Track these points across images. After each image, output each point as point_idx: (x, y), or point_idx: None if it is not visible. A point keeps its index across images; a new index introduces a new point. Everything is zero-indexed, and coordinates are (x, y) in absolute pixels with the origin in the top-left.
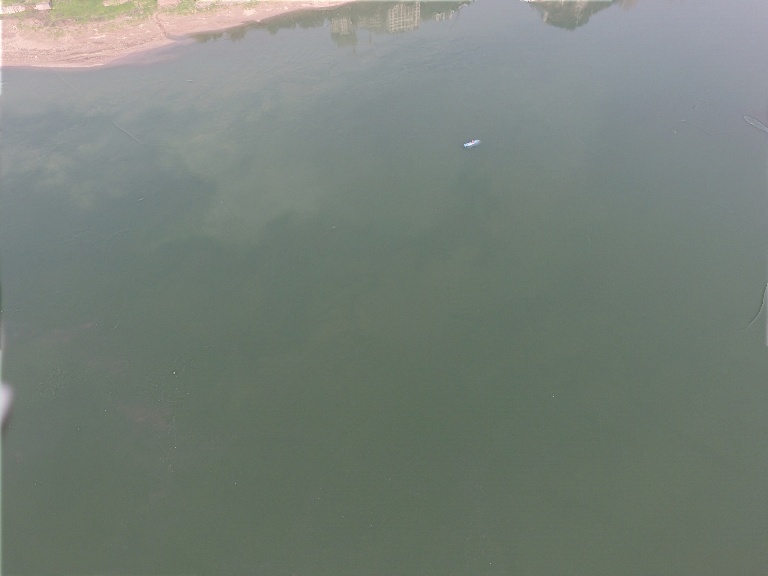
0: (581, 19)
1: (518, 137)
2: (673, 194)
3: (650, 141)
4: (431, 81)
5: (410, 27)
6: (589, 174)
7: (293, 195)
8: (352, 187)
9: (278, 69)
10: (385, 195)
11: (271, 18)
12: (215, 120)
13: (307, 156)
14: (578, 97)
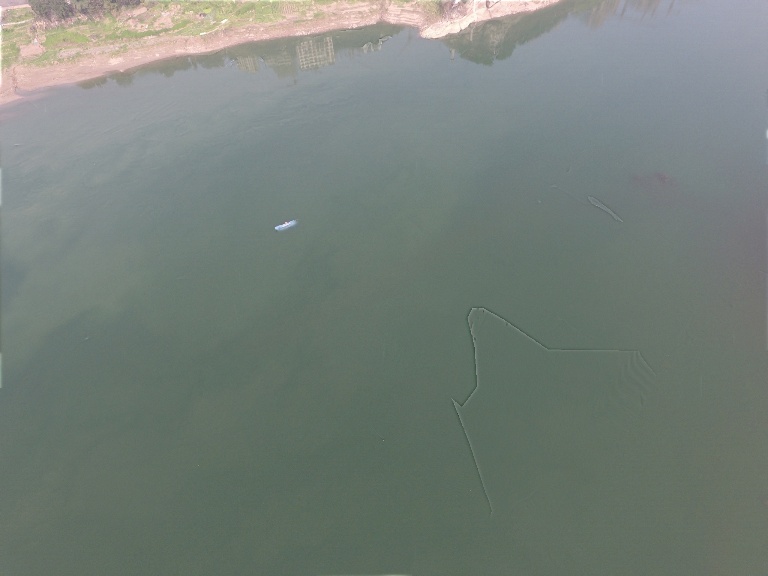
0: (500, 53)
1: (339, 216)
2: (508, 288)
3: (502, 216)
4: (279, 141)
5: (324, 63)
6: (408, 265)
7: (58, 294)
8: (131, 282)
9: (119, 128)
10: (163, 293)
11: (138, 67)
12: (23, 193)
13: (100, 240)
14: (424, 164)
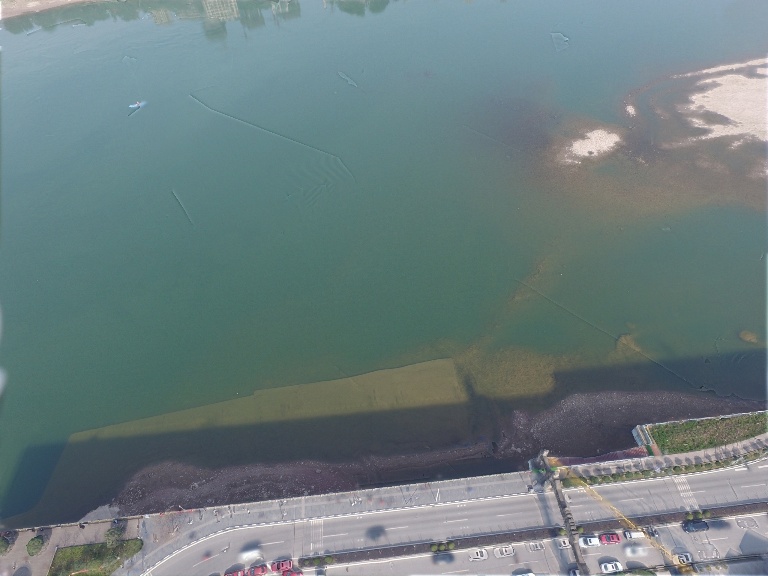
0: (373, 5)
1: None
2: None
3: (300, 100)
4: (151, 57)
5: (231, 18)
6: None
7: None
8: (14, 140)
9: (27, 50)
10: (35, 145)
11: (51, 9)
12: None
13: None
14: (247, 64)
